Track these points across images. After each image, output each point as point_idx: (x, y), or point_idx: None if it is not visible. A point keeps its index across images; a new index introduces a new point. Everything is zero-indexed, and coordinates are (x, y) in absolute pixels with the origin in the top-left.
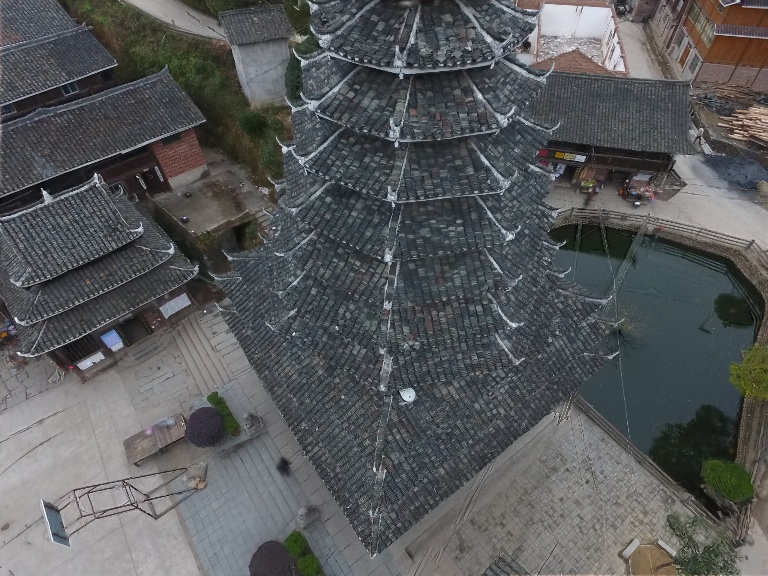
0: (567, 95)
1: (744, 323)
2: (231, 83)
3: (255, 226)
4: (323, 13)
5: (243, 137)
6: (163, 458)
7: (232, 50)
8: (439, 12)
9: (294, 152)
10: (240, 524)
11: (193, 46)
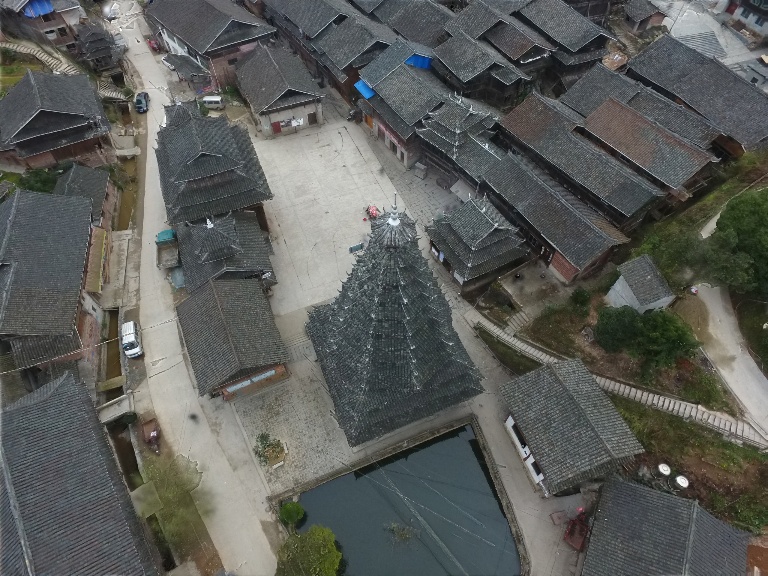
0: None
1: None
2: None
3: (509, 310)
4: None
5: None
6: None
7: None
8: None
9: None
10: None
11: None
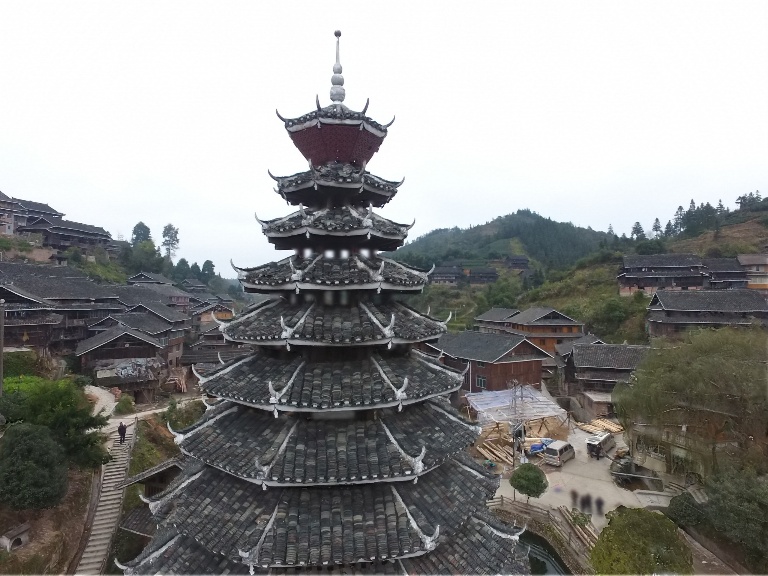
0: None
1: (542, 573)
2: None
3: None
4: (259, 274)
5: None
6: None
7: None
8: None
9: (271, 385)
10: None
11: None
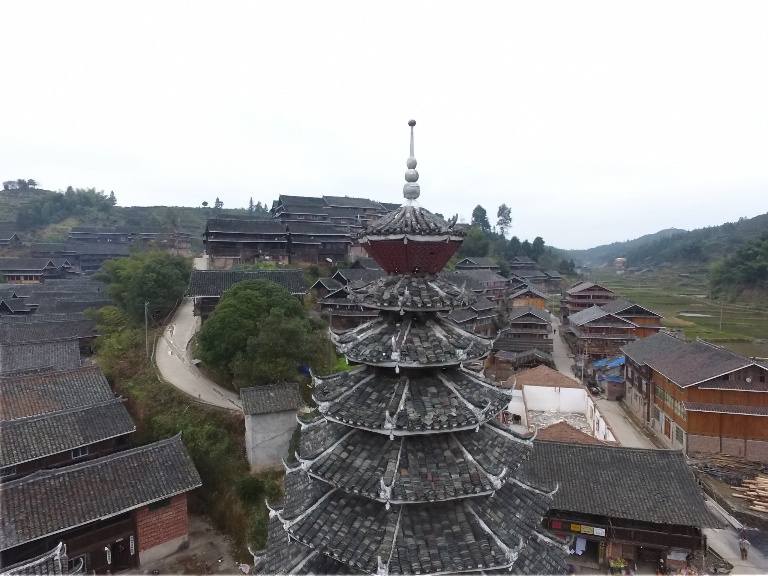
0: (565, 463)
1: None
2: (237, 448)
3: None
4: (326, 386)
5: (236, 503)
6: None
7: (245, 419)
8: (425, 385)
9: (279, 515)
10: None
11: (211, 415)
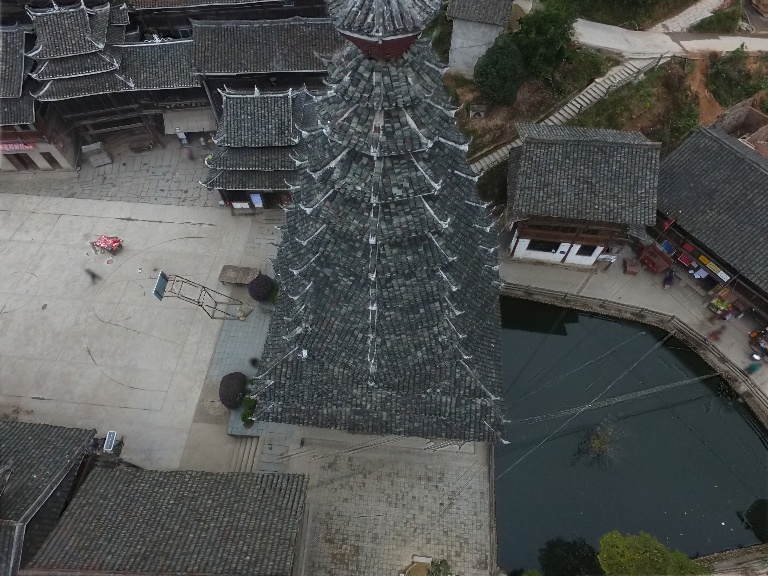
0: (761, 205)
1: (764, 540)
2: (448, 40)
3: None
4: None
5: None
6: (237, 289)
7: None
8: None
9: None
10: (244, 354)
11: None
